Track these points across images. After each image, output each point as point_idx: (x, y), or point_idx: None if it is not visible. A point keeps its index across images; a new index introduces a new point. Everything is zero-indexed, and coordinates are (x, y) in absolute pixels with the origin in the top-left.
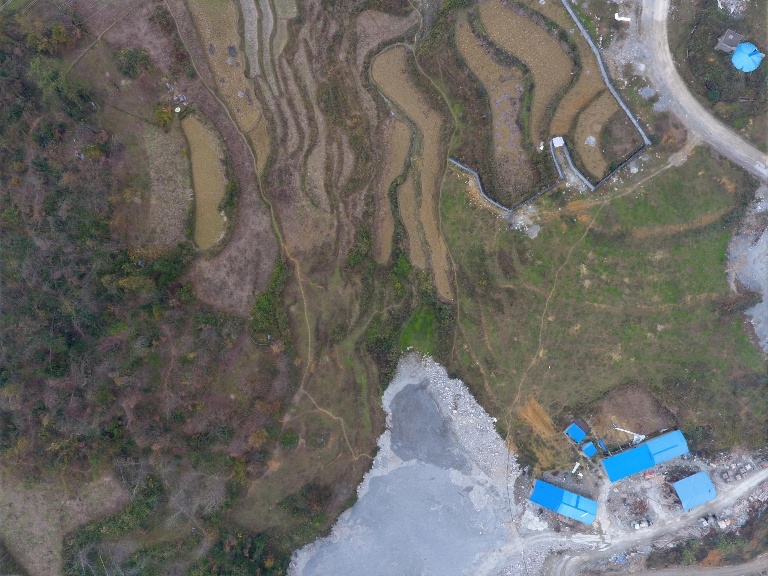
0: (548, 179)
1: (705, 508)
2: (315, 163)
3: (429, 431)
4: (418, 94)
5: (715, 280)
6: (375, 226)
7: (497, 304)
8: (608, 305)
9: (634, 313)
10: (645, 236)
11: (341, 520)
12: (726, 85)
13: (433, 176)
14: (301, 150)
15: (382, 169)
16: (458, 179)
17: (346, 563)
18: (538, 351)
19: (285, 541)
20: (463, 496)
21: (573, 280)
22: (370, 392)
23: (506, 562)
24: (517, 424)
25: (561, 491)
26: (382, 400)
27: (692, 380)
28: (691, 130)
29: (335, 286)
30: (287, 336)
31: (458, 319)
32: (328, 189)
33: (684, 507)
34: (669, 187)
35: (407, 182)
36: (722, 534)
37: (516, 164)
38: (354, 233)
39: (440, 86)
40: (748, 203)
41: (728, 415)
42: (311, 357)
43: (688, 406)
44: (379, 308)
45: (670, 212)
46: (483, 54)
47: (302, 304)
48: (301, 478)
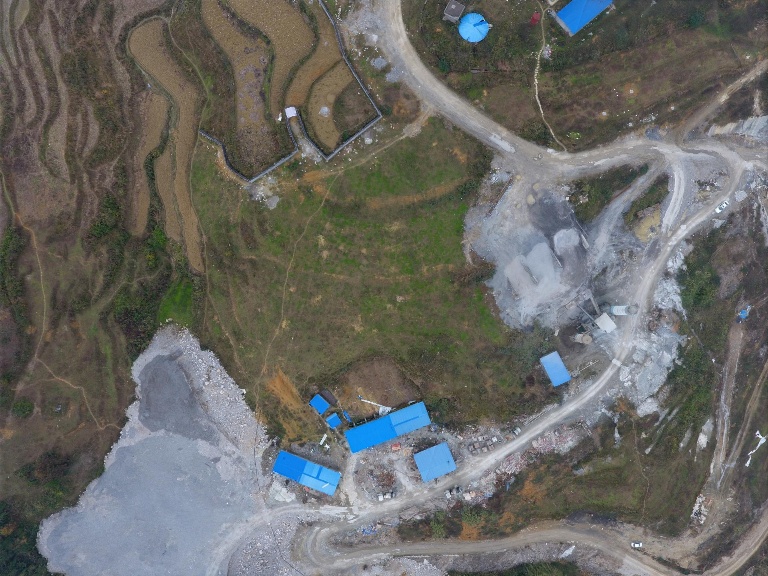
0: (285, 150)
1: (452, 480)
2: (57, 133)
3: (177, 402)
4: (175, 67)
5: (451, 251)
6: (129, 198)
7: (242, 275)
8: (346, 276)
9: (373, 284)
10: (380, 207)
11: (88, 490)
12: (453, 55)
13: (187, 148)
14: (40, 120)
15: (137, 141)
16: (208, 151)
17: (91, 532)
18: (281, 322)
19: (27, 510)
20: (210, 467)
21: (312, 251)
22: (117, 362)
23: (253, 533)
24: (264, 395)
25: (304, 462)
26: (131, 371)
27: (436, 352)
28: (424, 101)
29: (76, 256)
30: (17, 304)
31: (208, 290)
32: (68, 159)
33: (423, 478)
34: (402, 158)
35: (164, 154)
36: (469, 506)
37: (257, 135)
38: (97, 203)
39: (192, 58)
40: (484, 174)
41: (474, 387)
42: (46, 326)
43: (433, 378)
44: (127, 279)
45: (403, 183)
46: (229, 26)
47: (38, 273)
48: (39, 447)
